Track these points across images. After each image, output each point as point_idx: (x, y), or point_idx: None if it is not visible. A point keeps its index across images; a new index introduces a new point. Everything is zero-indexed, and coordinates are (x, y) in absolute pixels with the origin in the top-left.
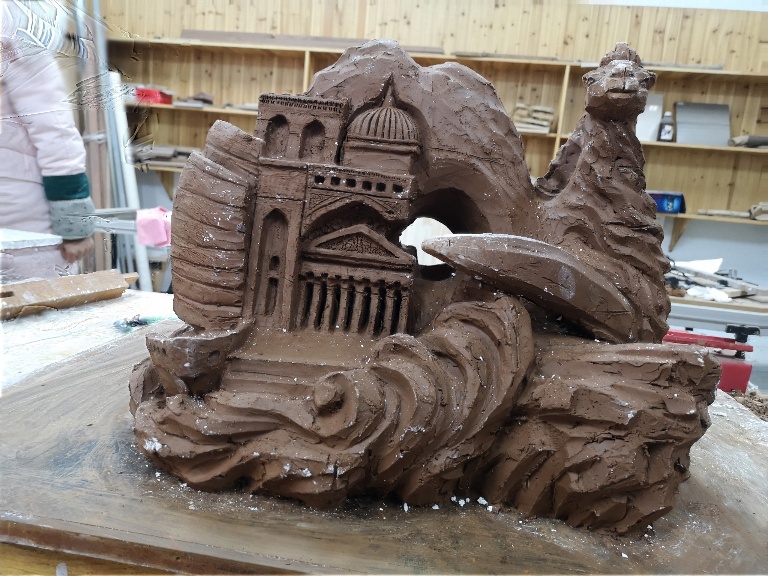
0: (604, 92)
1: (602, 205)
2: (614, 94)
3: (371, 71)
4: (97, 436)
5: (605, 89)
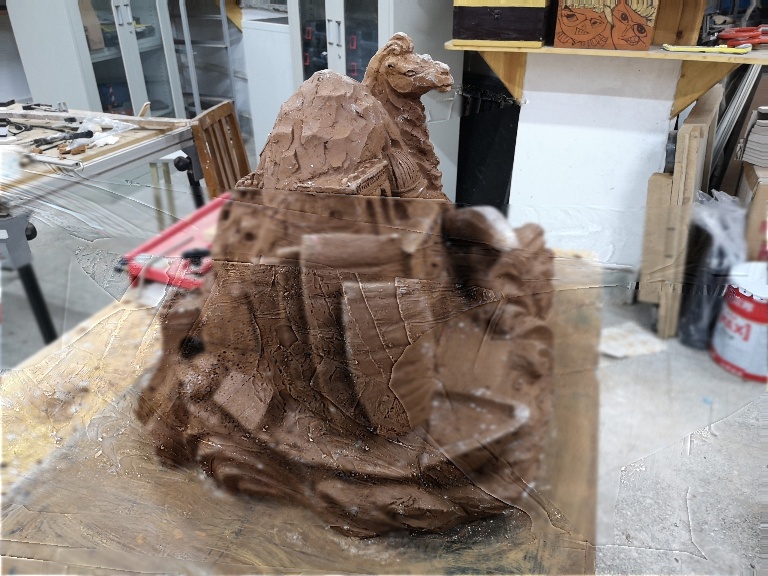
0: (433, 84)
1: (423, 159)
2: (448, 88)
3: (375, 120)
4: (437, 570)
5: (438, 83)
